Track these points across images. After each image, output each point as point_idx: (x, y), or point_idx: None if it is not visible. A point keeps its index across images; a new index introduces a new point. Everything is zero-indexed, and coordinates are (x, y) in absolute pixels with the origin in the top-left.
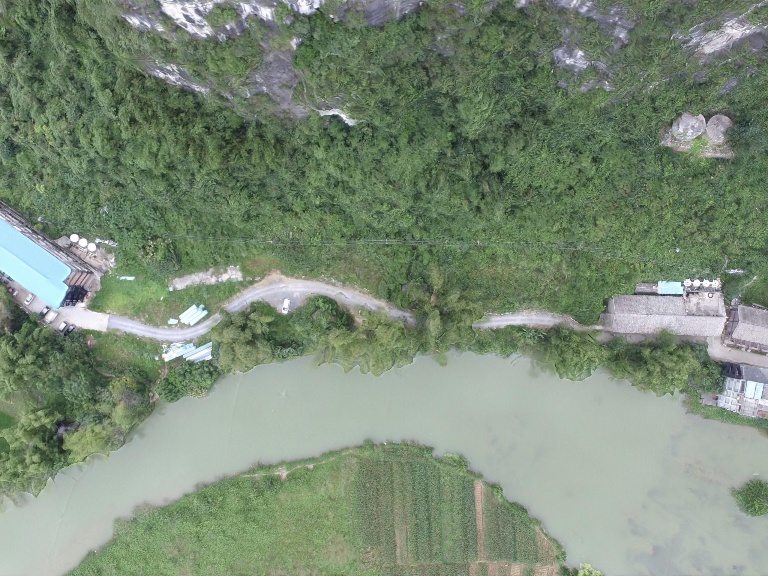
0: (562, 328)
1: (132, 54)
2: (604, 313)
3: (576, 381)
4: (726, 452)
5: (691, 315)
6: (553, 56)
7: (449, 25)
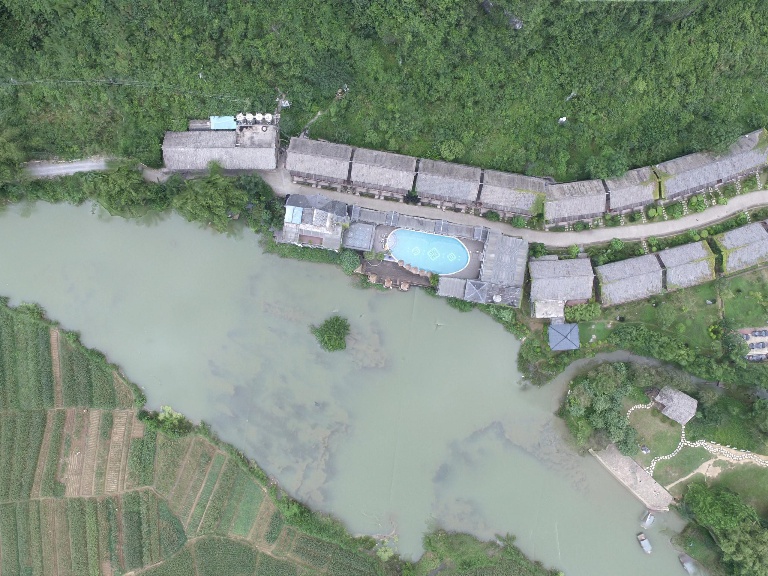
0: (123, 170)
1: None
2: None
3: (160, 229)
4: (305, 290)
5: (238, 147)
6: None
7: None
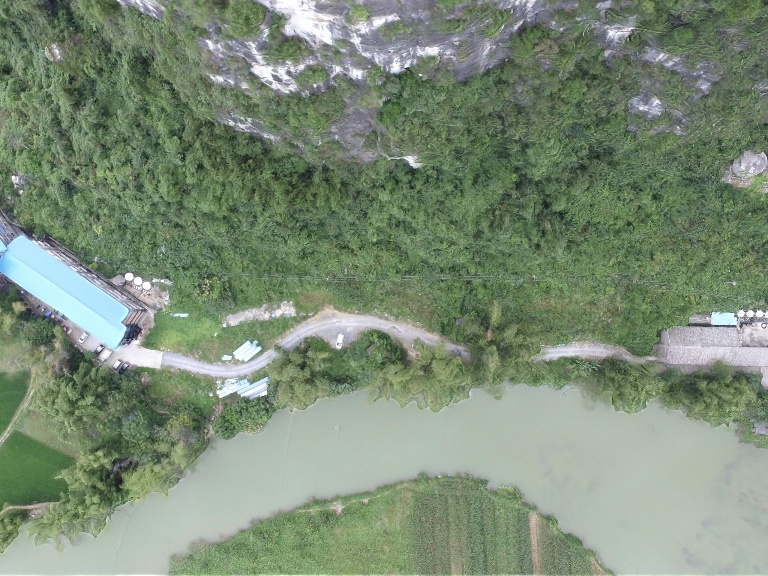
0: (616, 360)
1: (212, 109)
2: (657, 344)
3: None
4: None
5: (746, 346)
6: (627, 103)
7: (532, 79)
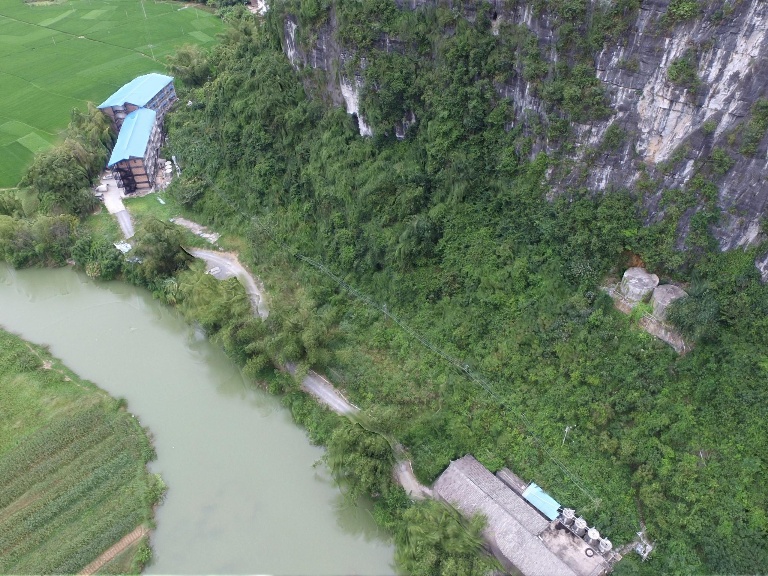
0: None
1: None
2: None
3: (355, 546)
4: None
5: None
6: (514, 100)
7: (440, 17)
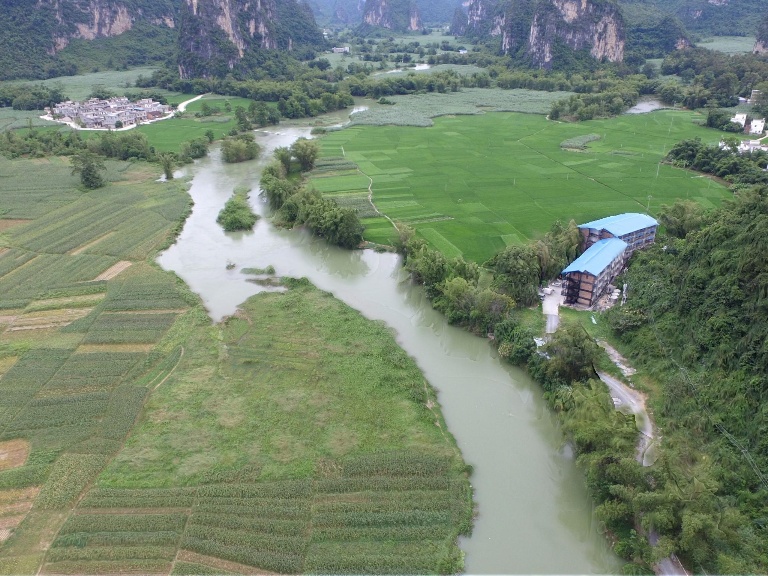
0: None
1: None
2: None
3: None
4: None
5: None
6: None
7: None
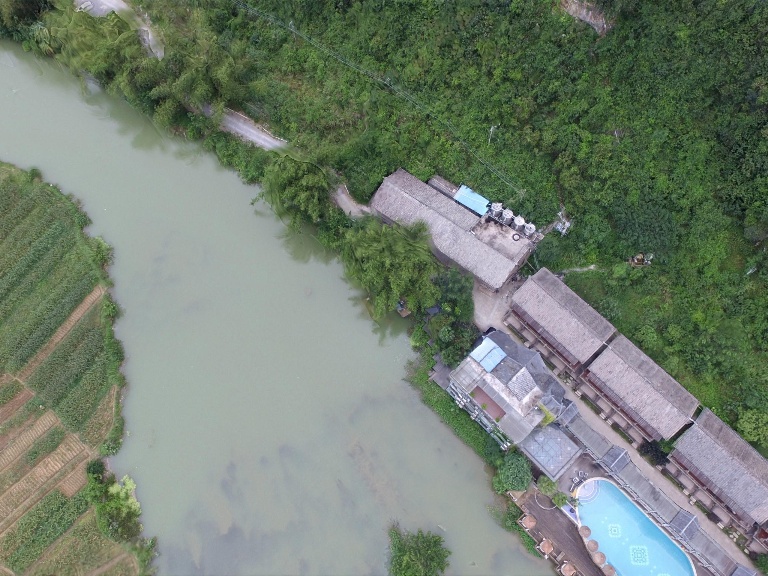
0: None
1: None
2: None
3: (306, 268)
4: (422, 467)
5: None
6: None
7: None
